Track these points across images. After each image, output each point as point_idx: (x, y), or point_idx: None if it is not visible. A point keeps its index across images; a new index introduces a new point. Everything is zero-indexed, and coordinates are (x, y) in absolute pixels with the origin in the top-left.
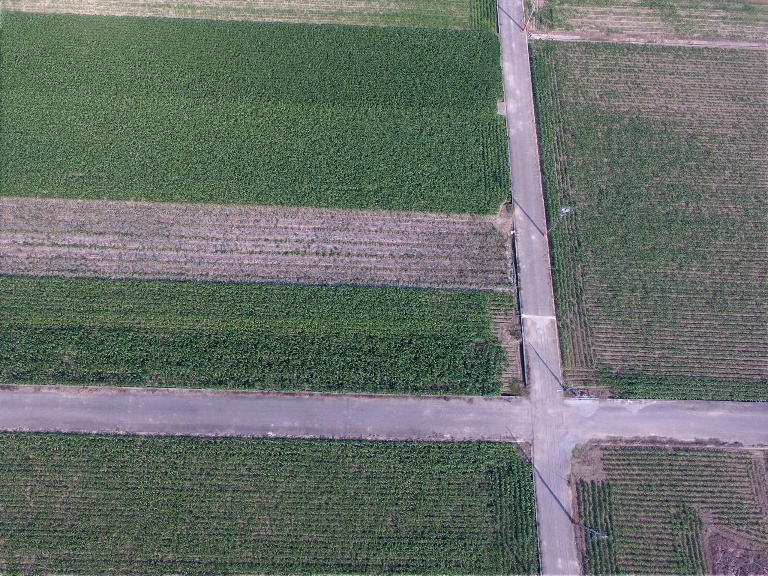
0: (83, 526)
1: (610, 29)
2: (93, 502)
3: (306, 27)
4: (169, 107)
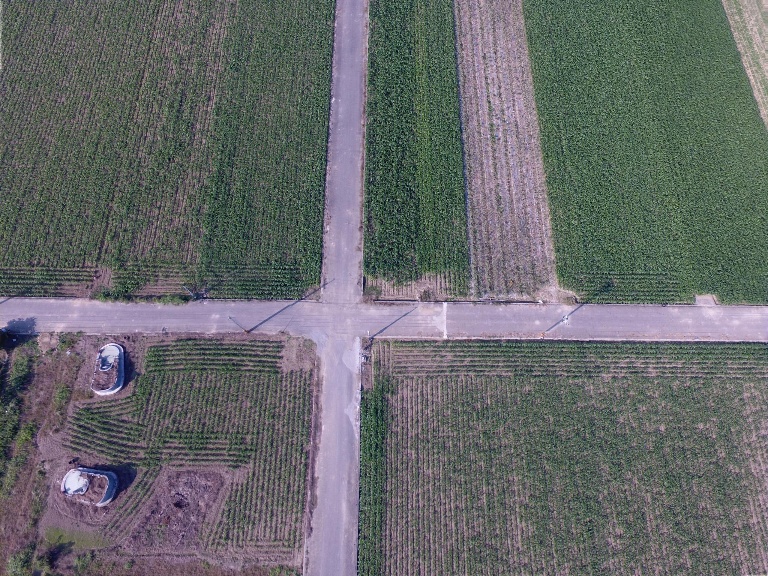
0: (276, 1)
1: None
2: (291, 5)
3: (751, 100)
4: (619, 5)
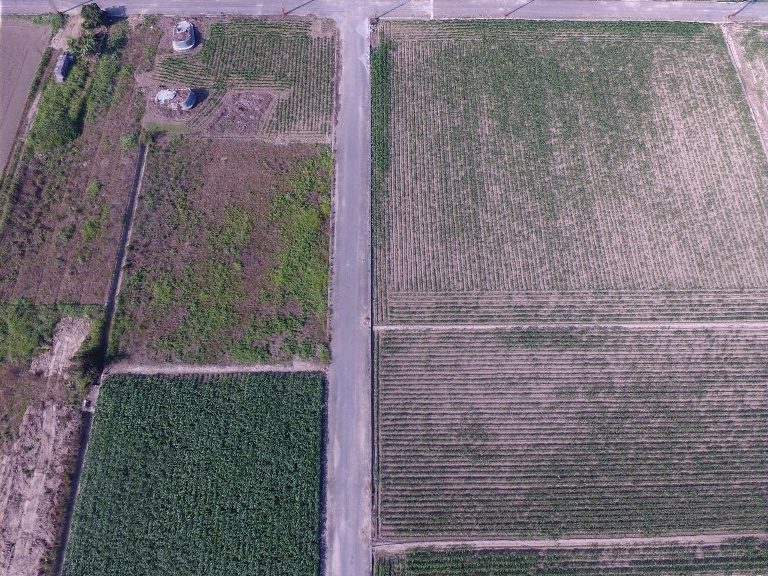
0: None
1: (763, 92)
2: None
3: None
4: None
